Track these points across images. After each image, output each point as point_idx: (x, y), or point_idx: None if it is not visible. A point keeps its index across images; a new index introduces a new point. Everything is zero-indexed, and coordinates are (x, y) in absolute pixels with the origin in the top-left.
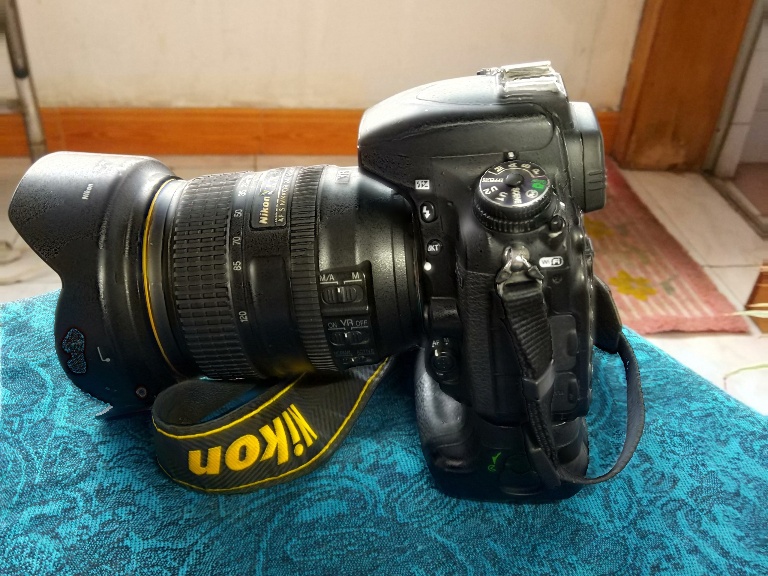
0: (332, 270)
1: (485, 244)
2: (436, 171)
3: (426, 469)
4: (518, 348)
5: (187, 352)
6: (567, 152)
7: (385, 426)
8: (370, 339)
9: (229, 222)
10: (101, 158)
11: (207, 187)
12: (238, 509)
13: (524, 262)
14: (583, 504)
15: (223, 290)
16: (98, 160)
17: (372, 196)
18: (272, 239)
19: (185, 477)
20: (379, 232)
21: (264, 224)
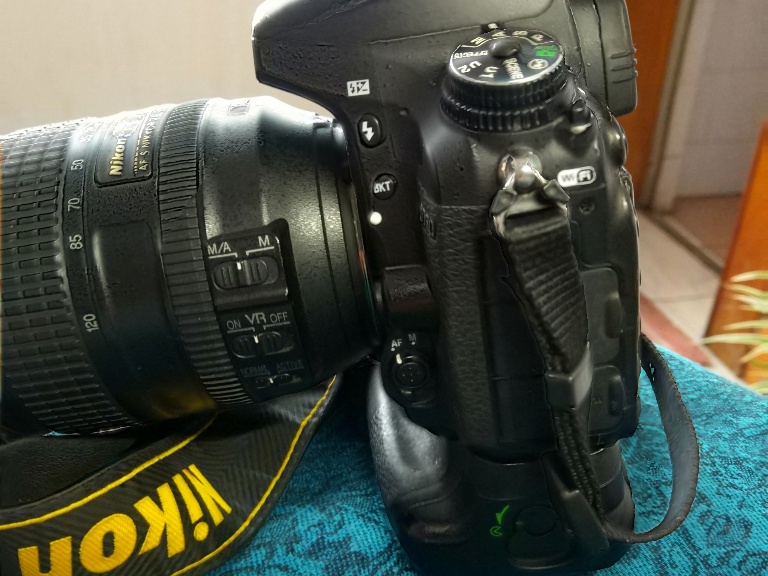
0: (226, 236)
1: (467, 156)
2: (378, 64)
3: (395, 542)
4: (536, 322)
5: (8, 389)
6: (575, 24)
7: (331, 485)
8: (295, 343)
9: (63, 178)
10: None
11: (34, 137)
12: None
13: (536, 174)
14: (628, 573)
15: (55, 282)
16: None
17: (284, 128)
18: (130, 197)
19: None
20: (297, 177)
21: (117, 175)
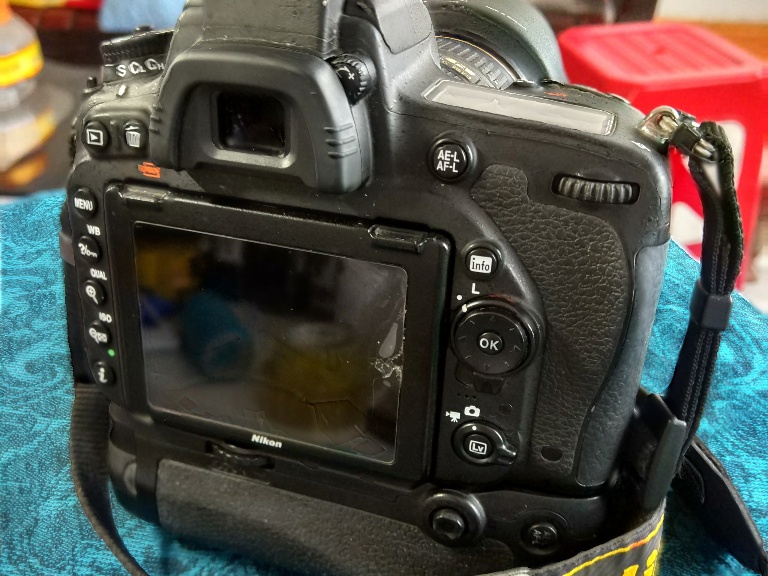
0: None
1: None
2: None
3: None
4: None
5: None
6: None
7: None
8: None
9: None
10: (479, 2)
11: None
12: None
13: None
14: (135, 545)
15: None
16: (473, 0)
17: None
18: None
19: None
20: None
21: None
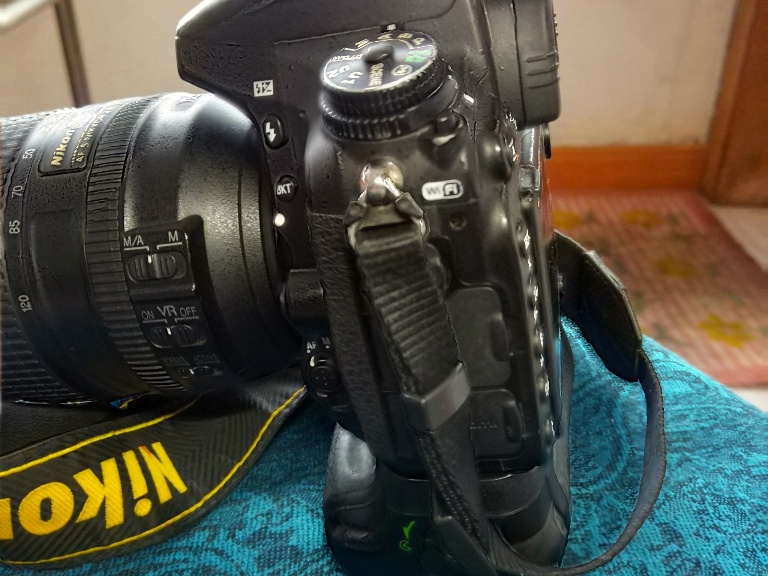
0: (142, 229)
1: (333, 164)
2: (282, 64)
3: None
4: (389, 339)
5: None
6: (489, 25)
7: (292, 477)
8: (207, 338)
9: (13, 166)
10: None
11: (7, 126)
12: None
13: (388, 186)
14: None
15: None
16: None
17: (219, 125)
18: (64, 187)
19: None
20: (220, 174)
21: (56, 166)
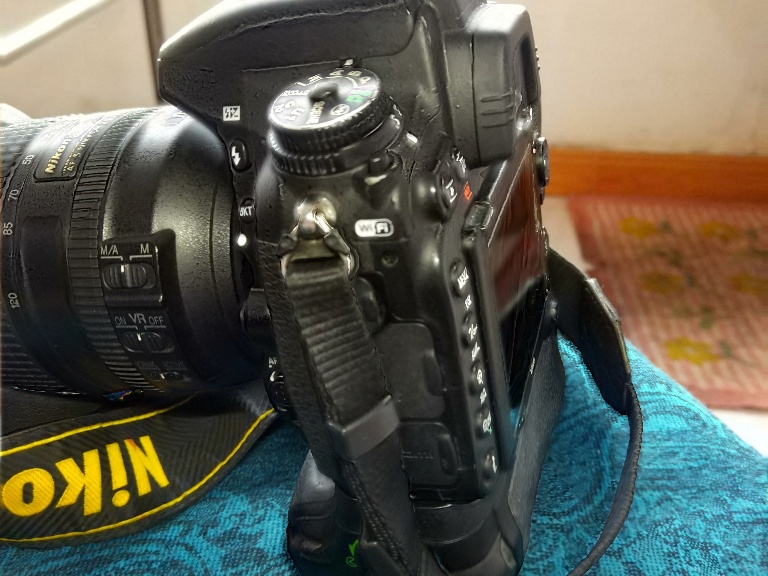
0: (118, 239)
1: (275, 195)
2: (248, 92)
3: None
4: (315, 369)
5: None
6: (446, 63)
7: (272, 480)
8: (175, 346)
9: (13, 170)
10: None
11: (17, 130)
12: (22, 570)
13: (317, 222)
14: None
15: None
16: None
17: (202, 142)
18: (54, 194)
19: None
20: (196, 190)
21: (49, 173)
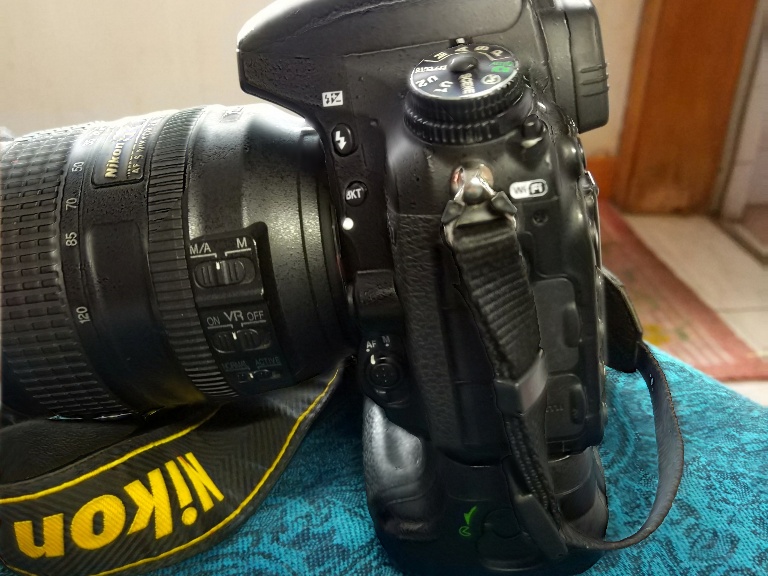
0: (208, 237)
1: (423, 167)
2: (351, 76)
3: (377, 537)
4: (483, 329)
5: (11, 374)
6: (545, 39)
7: (323, 479)
8: (272, 341)
9: (63, 179)
10: None
11: (44, 140)
12: None
13: (484, 186)
14: None
15: (51, 276)
16: None
17: (271, 136)
18: (122, 198)
19: (20, 562)
20: (279, 182)
21: (111, 178)
